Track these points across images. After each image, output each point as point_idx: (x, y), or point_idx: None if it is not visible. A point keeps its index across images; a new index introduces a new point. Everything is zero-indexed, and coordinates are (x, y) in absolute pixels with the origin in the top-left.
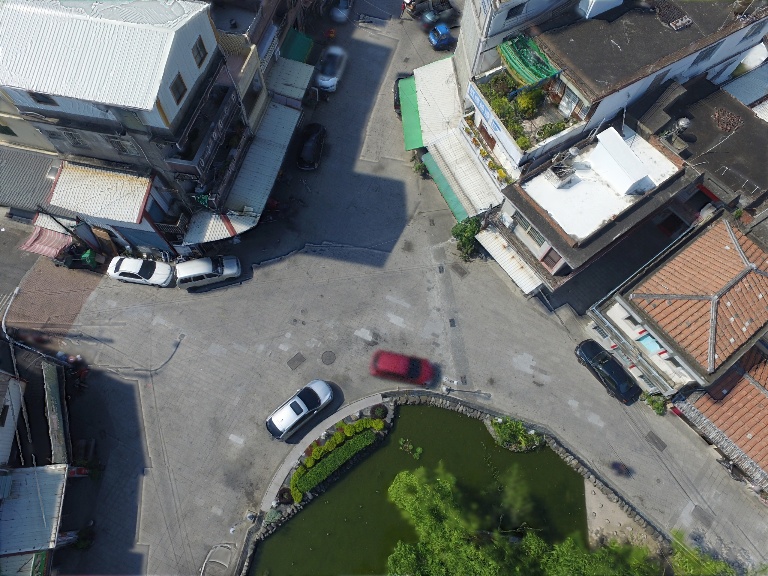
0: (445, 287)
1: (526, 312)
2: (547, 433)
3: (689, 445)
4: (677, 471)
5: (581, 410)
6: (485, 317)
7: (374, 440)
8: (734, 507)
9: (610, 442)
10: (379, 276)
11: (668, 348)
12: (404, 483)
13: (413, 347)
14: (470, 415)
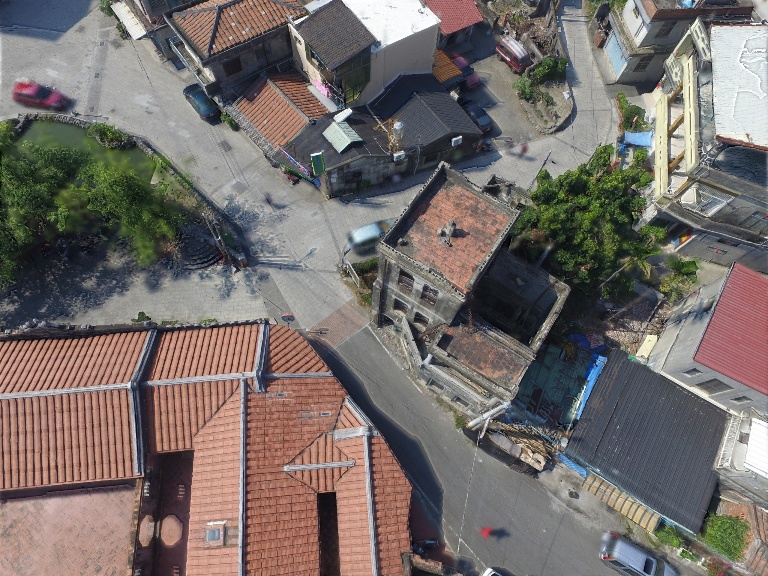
0: (100, 54)
1: (158, 70)
2: (143, 141)
3: (249, 148)
4: (233, 163)
5: (175, 128)
6: (124, 73)
7: None
8: (266, 183)
9: (189, 146)
10: (50, 47)
11: (185, 44)
12: None
13: (59, 89)
14: (84, 126)
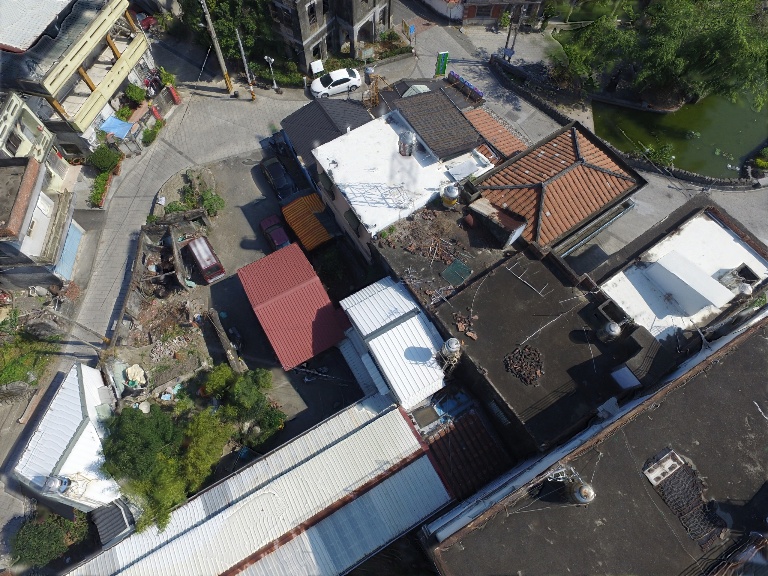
0: None
1: None
2: None
3: None
4: None
5: None
6: None
7: (762, 151)
8: None
9: None
10: None
11: None
12: (763, 98)
13: (743, 221)
14: (686, 171)
